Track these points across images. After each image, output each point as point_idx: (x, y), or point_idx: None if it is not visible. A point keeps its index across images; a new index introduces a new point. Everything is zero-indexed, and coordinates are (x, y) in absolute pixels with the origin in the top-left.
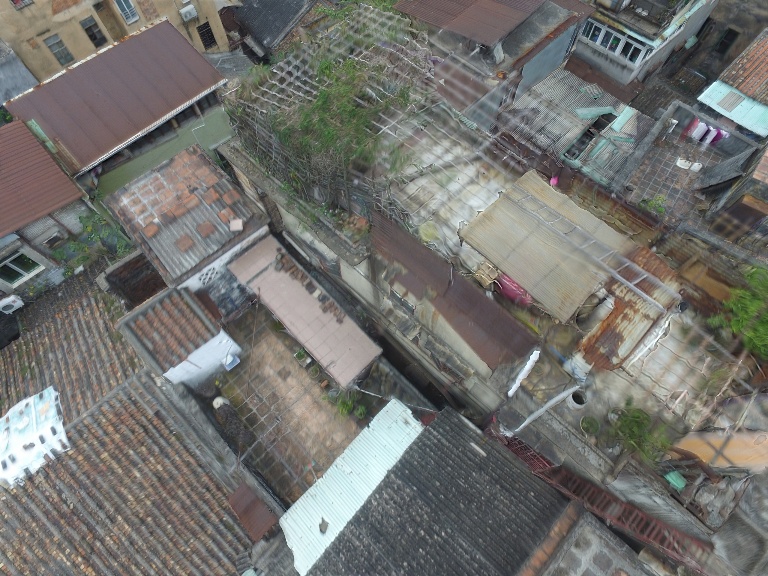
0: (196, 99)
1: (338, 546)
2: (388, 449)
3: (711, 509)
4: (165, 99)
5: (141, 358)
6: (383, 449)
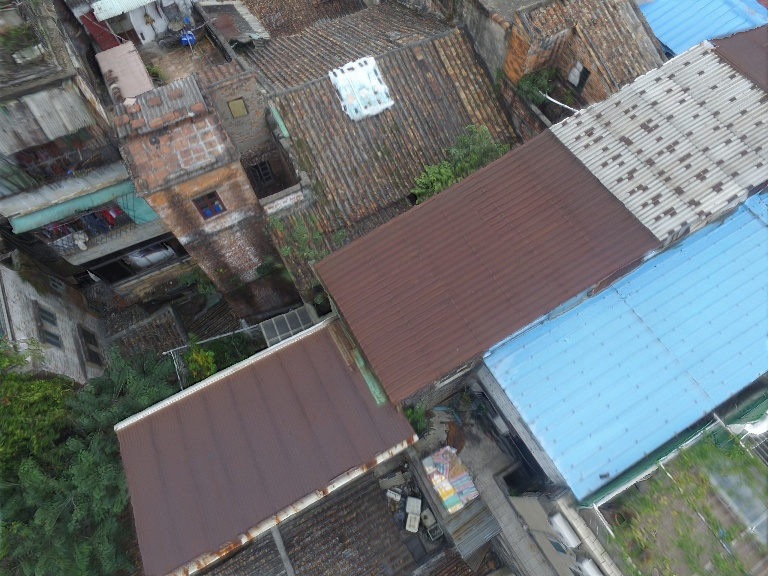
0: (167, 402)
1: None
2: (117, 0)
3: None
4: (206, 410)
5: (274, 108)
6: (120, 1)
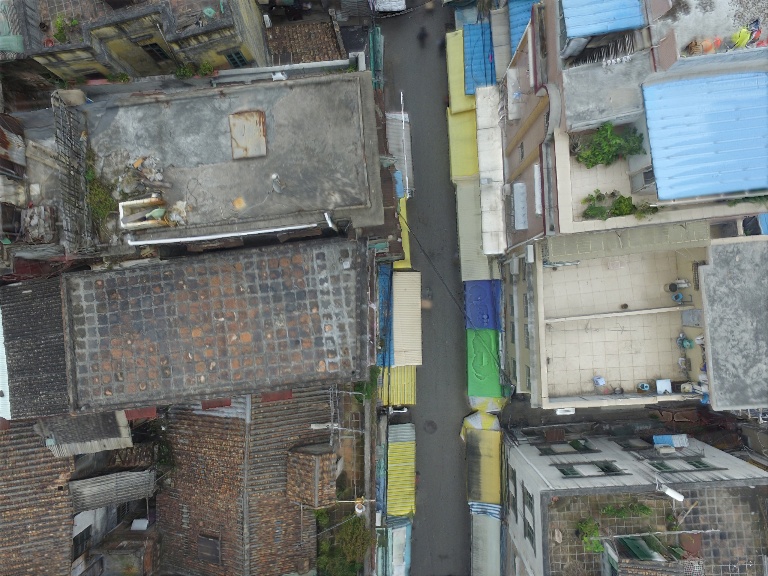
0: None
1: (12, 394)
2: None
3: (40, 236)
4: None
5: None
6: None
